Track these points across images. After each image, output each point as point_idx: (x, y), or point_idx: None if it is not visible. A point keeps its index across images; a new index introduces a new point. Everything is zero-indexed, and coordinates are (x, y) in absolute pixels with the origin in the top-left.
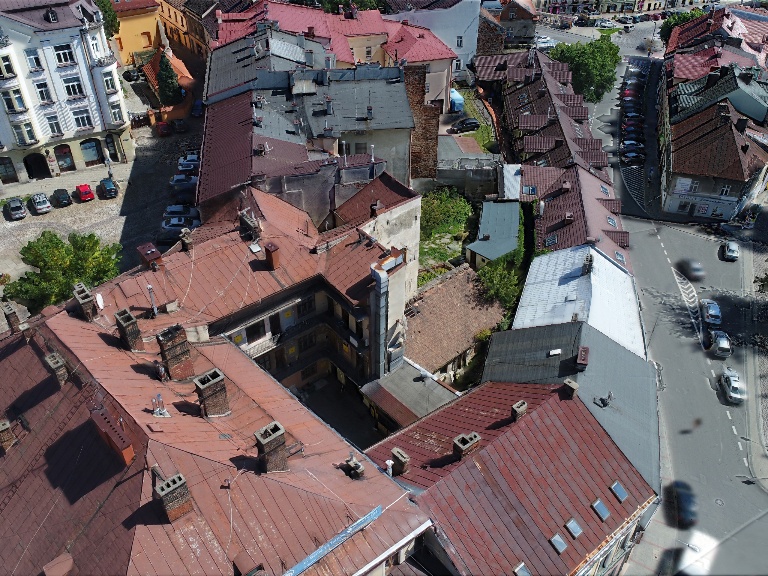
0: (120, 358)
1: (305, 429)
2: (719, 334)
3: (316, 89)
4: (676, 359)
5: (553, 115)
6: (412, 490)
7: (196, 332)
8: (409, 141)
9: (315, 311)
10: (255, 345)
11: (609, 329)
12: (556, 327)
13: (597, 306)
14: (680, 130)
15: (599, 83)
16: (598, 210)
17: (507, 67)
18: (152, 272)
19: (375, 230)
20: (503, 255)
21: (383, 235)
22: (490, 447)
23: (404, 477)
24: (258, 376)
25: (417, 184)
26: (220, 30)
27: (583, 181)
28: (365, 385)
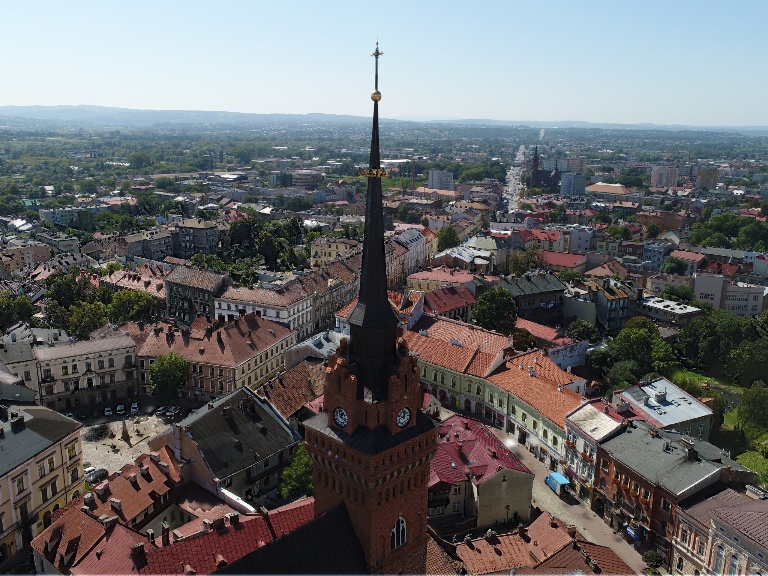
0: None
1: None
2: None
3: None
4: None
5: None
6: None
7: None
8: None
9: None
10: None
11: None
12: None
13: None
14: None
15: None
16: None
17: None
18: None
19: None
20: None
21: None
22: None
23: None
24: None
25: None
26: None
27: None
28: None
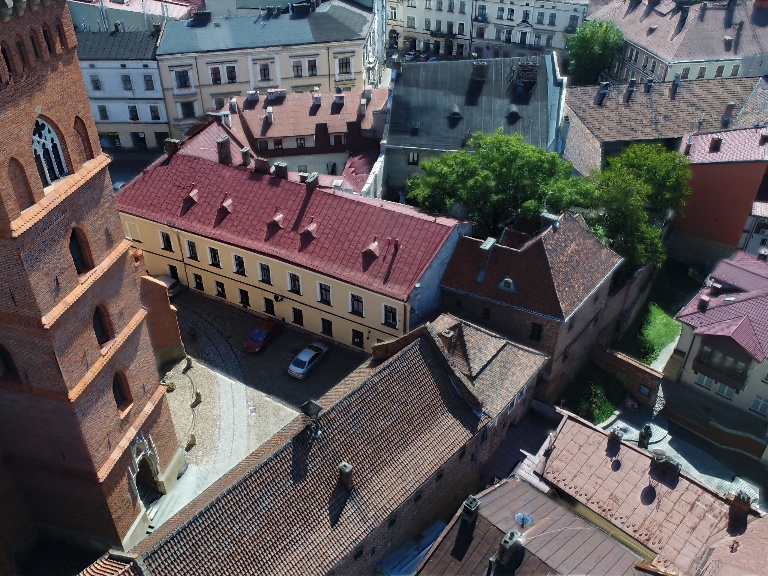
0: None
1: None
2: None
3: None
4: None
5: None
6: None
7: None
8: None
9: None
10: None
11: None
12: None
13: None
14: None
15: None
16: None
17: None
18: None
19: None
20: None
21: None
22: None
23: None
24: None
25: None
26: None
27: None
28: None
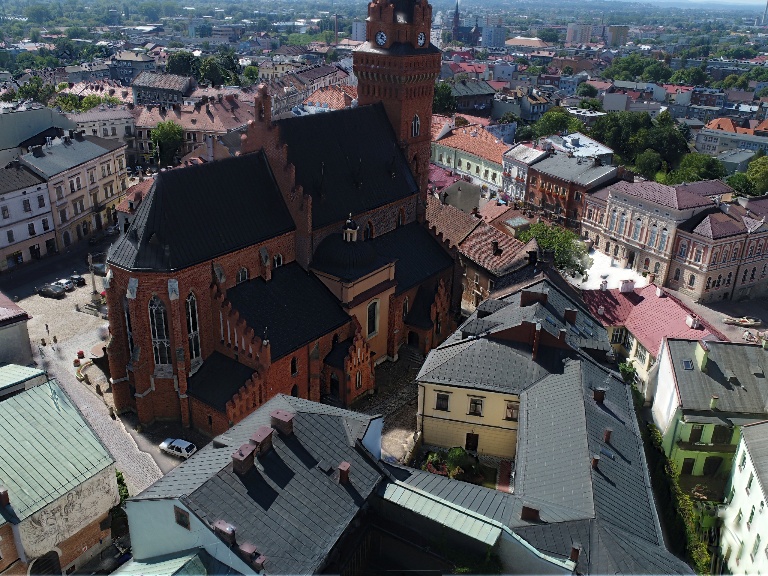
0: None
1: None
2: None
3: None
4: None
5: None
6: None
7: None
8: None
9: None
10: None
11: None
12: None
13: None
14: None
15: None
16: None
17: None
18: None
19: None
20: None
21: None
22: None
23: None
24: None
25: None
26: None
27: None
28: None
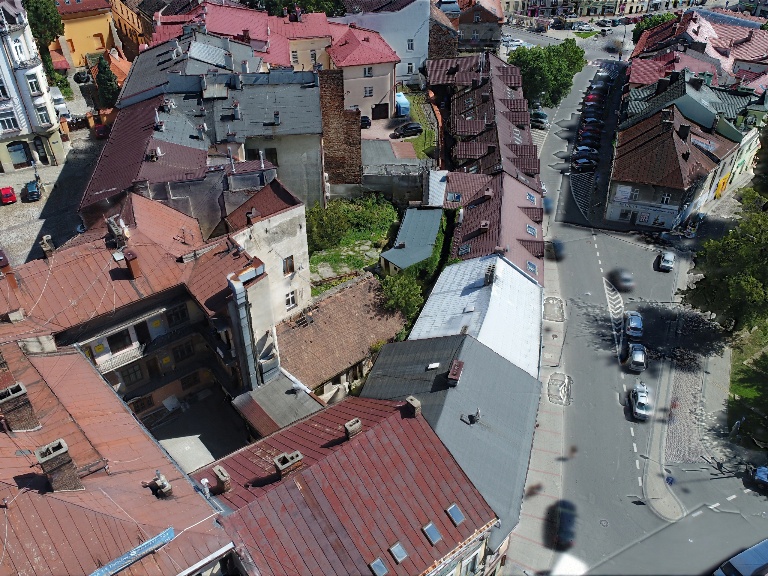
0: None
1: (126, 445)
2: (636, 347)
3: (228, 93)
4: (589, 372)
5: (492, 120)
6: (223, 510)
7: (38, 342)
8: (320, 147)
9: (189, 320)
10: (117, 355)
11: (502, 342)
12: (441, 340)
13: (493, 318)
14: (626, 136)
15: (555, 88)
16: (518, 218)
17: (459, 71)
18: None
19: (252, 238)
20: (415, 264)
21: (262, 244)
22: (315, 467)
23: (224, 496)
24: (97, 388)
25: (343, 190)
26: (157, 32)
27: (507, 188)
28: (237, 397)
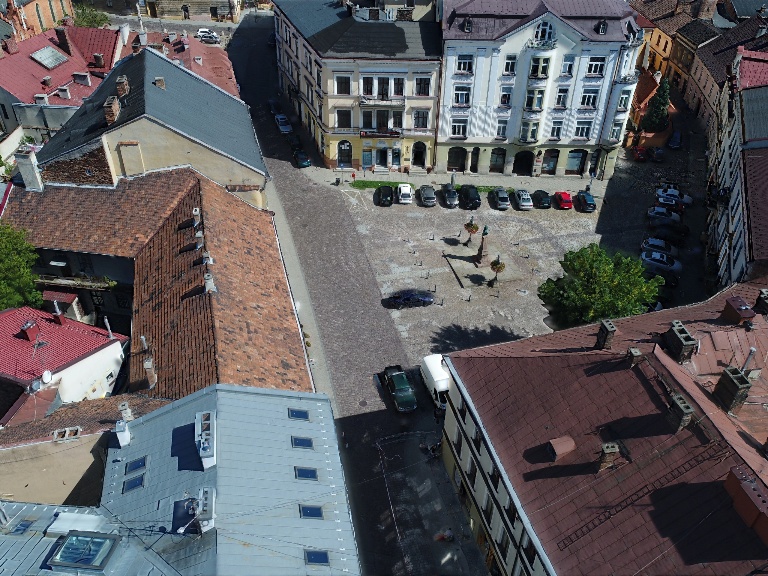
0: (725, 419)
1: None
2: None
3: None
4: None
5: None
6: None
7: None
8: None
9: None
10: None
11: None
12: None
13: None
14: None
15: None
16: None
17: None
18: (744, 331)
19: None
20: None
21: None
22: None
23: None
24: None
25: None
26: (740, 67)
27: None
28: None
